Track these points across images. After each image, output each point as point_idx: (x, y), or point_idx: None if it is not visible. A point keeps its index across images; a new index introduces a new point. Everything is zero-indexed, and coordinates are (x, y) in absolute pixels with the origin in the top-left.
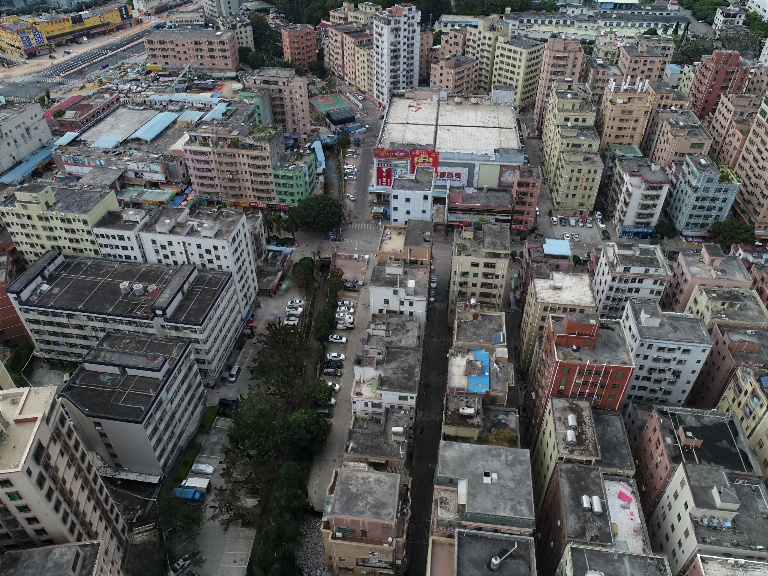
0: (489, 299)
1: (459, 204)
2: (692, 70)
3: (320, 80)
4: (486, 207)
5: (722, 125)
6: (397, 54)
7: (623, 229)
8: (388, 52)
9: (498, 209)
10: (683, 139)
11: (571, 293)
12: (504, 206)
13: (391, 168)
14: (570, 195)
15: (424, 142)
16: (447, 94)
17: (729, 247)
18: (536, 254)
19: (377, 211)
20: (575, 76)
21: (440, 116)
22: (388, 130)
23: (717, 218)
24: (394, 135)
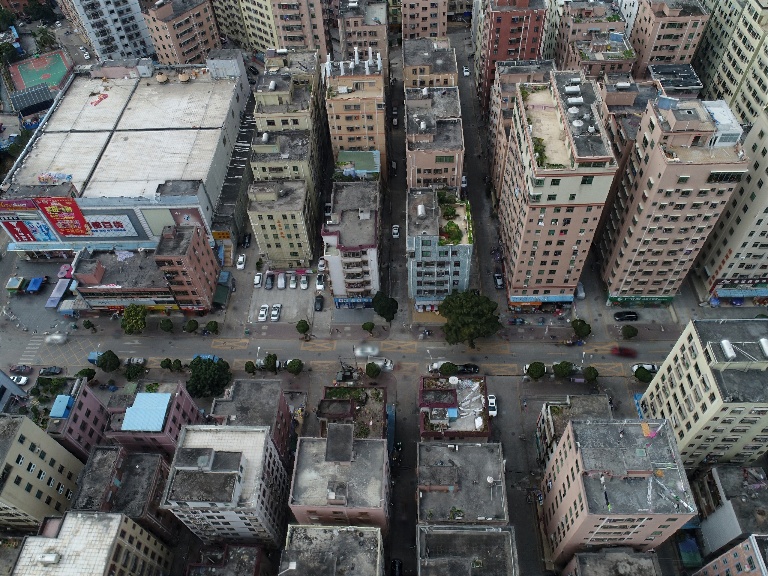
0: (24, 523)
1: (92, 288)
2: (483, 7)
3: (45, 27)
4: (131, 289)
5: (495, 112)
6: (93, 1)
7: (335, 300)
8: (76, 1)
9: (150, 290)
10: (422, 152)
11: (70, 572)
12: (155, 287)
13: (21, 221)
14: (273, 245)
15: (78, 169)
16: (151, 67)
17: (456, 341)
18: (114, 427)
19: (10, 287)
20: (319, 30)
21: (126, 111)
22: (38, 148)
23: (456, 283)
24: (41, 158)
